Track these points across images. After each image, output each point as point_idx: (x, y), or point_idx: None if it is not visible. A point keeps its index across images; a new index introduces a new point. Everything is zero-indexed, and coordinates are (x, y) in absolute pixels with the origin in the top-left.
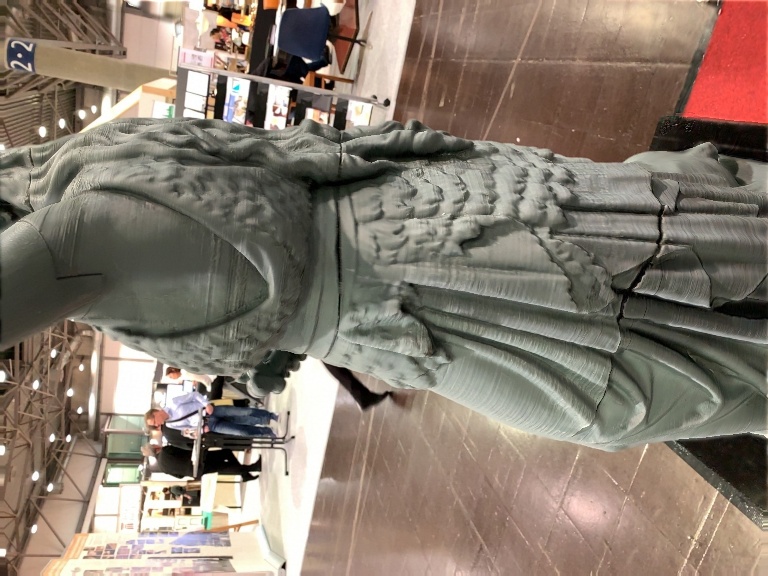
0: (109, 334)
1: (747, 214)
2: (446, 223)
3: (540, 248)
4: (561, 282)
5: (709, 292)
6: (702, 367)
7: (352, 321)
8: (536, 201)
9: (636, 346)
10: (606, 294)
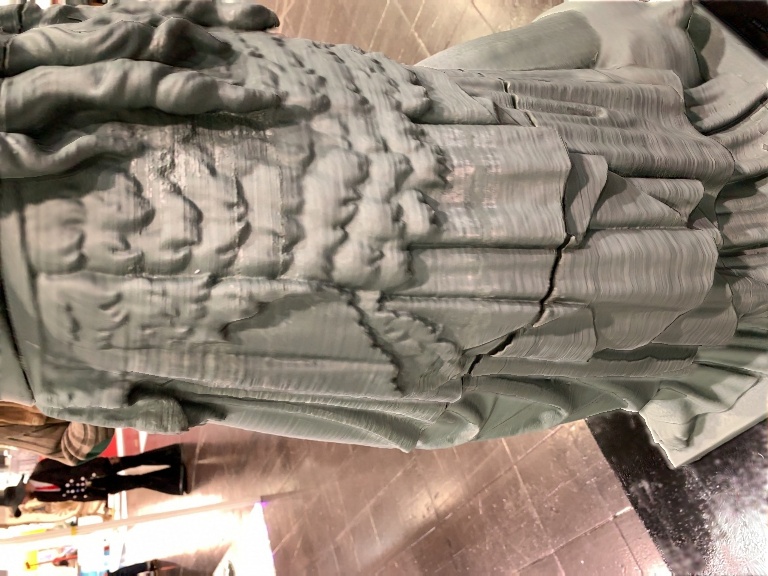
0: None
1: (684, 205)
2: (198, 296)
3: (358, 330)
4: (383, 374)
5: (590, 355)
6: (559, 386)
7: (51, 403)
8: (366, 246)
9: (482, 388)
10: (449, 370)
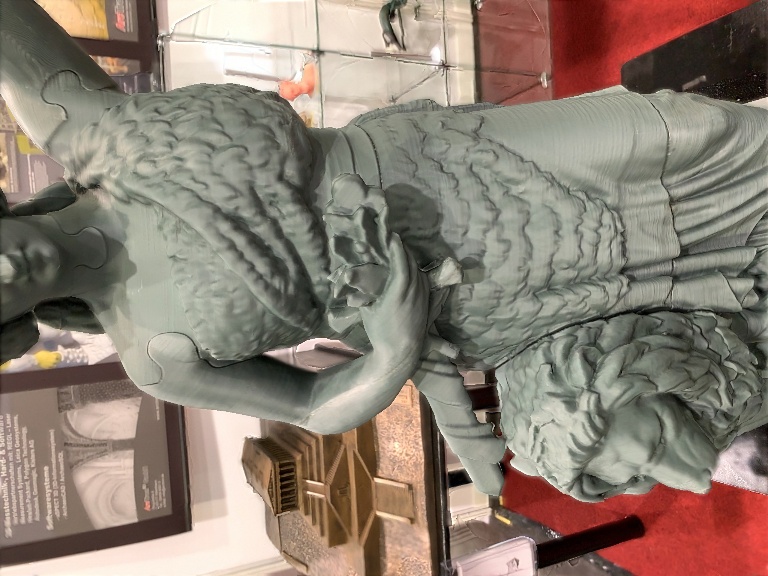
0: (127, 101)
1: None
2: None
3: None
4: None
5: None
6: None
7: None
8: None
9: None
10: None
